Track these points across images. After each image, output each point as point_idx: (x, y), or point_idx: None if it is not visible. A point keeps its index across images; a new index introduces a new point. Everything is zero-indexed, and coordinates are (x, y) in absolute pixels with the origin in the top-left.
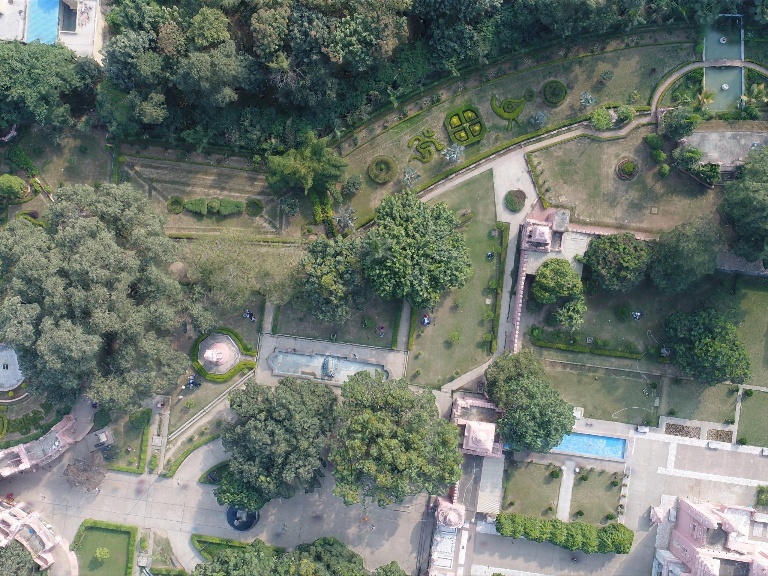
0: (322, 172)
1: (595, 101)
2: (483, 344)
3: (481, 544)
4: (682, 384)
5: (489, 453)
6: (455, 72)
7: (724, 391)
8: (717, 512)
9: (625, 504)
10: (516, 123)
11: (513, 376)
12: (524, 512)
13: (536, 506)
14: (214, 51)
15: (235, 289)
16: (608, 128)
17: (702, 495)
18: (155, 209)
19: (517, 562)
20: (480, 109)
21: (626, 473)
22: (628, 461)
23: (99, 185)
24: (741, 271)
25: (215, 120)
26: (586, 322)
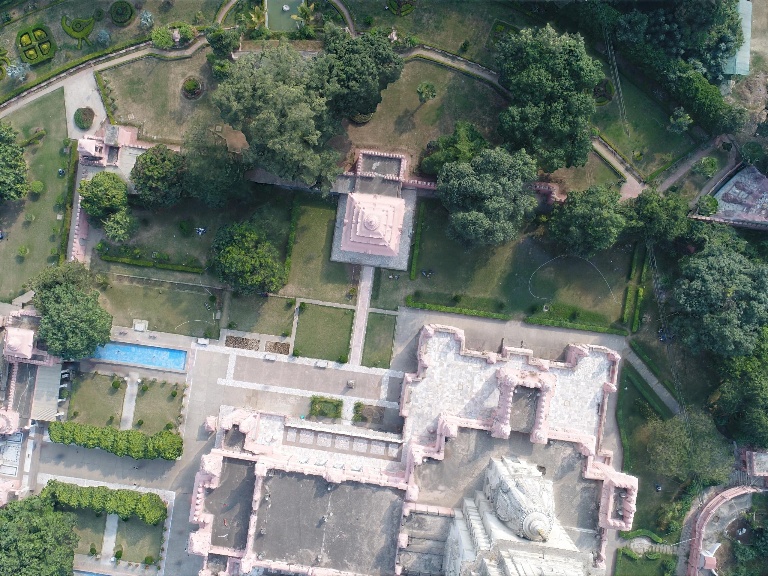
0: None
1: (162, 21)
2: (54, 259)
3: (47, 453)
4: (242, 298)
5: (38, 361)
6: None
7: (282, 305)
8: (248, 417)
9: (186, 414)
10: (86, 42)
11: (51, 284)
12: (89, 422)
13: (101, 416)
14: None
15: None
16: (174, 48)
17: (259, 405)
18: None
19: (81, 470)
20: (51, 28)
21: (187, 384)
22: (189, 372)
23: None
24: (298, 187)
25: None
26: (152, 237)
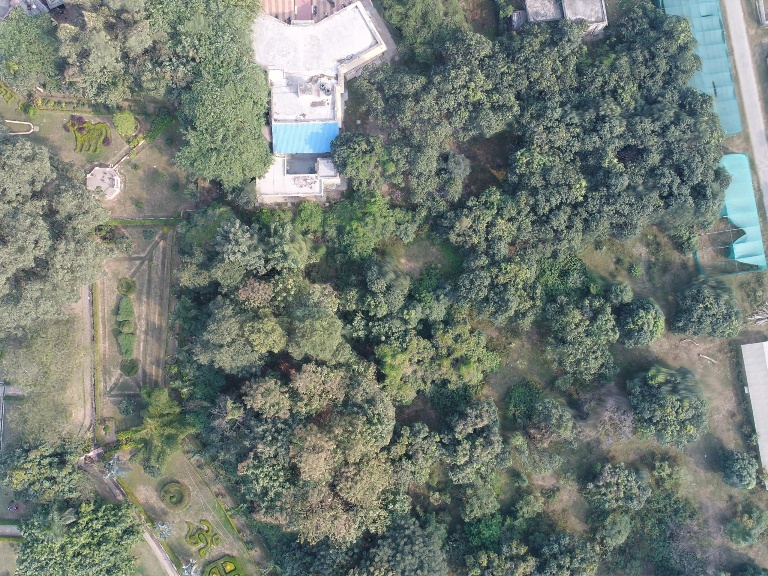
0: (154, 444)
1: None
2: None
3: None
4: None
5: None
6: (266, 571)
7: None
8: None
9: None
10: None
11: None
12: None
13: None
14: (240, 343)
15: (14, 375)
16: None
17: None
18: (122, 265)
19: None
20: None
21: None
22: None
23: (140, 207)
24: None
25: (203, 327)
26: None
